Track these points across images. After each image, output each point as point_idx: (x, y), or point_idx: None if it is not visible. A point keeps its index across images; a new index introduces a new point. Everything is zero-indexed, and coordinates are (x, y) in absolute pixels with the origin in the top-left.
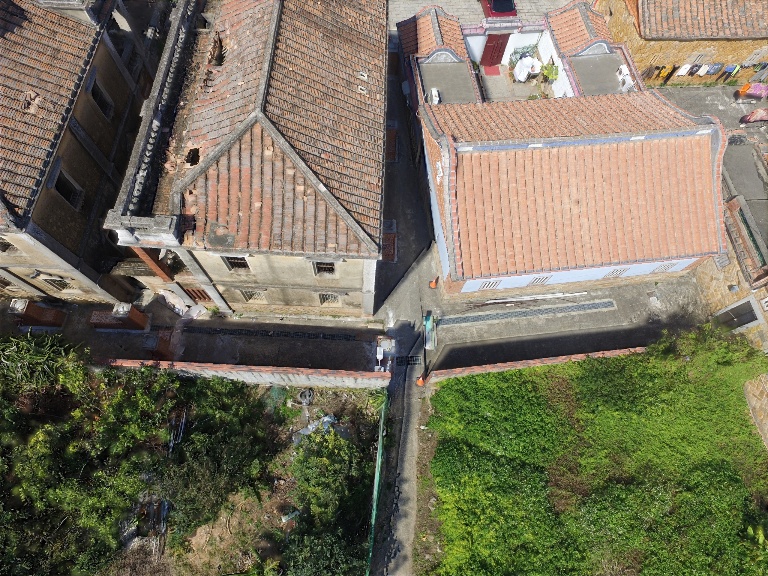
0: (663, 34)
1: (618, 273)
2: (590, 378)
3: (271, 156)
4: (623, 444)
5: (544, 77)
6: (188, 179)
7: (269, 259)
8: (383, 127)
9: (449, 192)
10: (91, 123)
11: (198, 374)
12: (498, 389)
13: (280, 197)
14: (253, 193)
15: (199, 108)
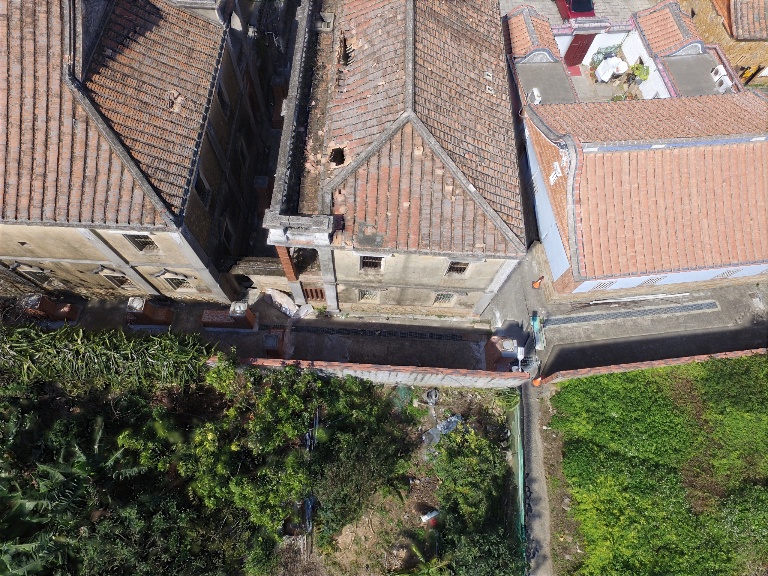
0: (755, 35)
1: (728, 274)
2: (716, 379)
3: (421, 156)
4: (754, 445)
5: (628, 77)
6: (339, 179)
7: (408, 259)
8: (512, 127)
9: (573, 192)
10: (216, 122)
11: (332, 373)
12: (624, 390)
13: (429, 197)
14: (402, 193)
15: (337, 108)
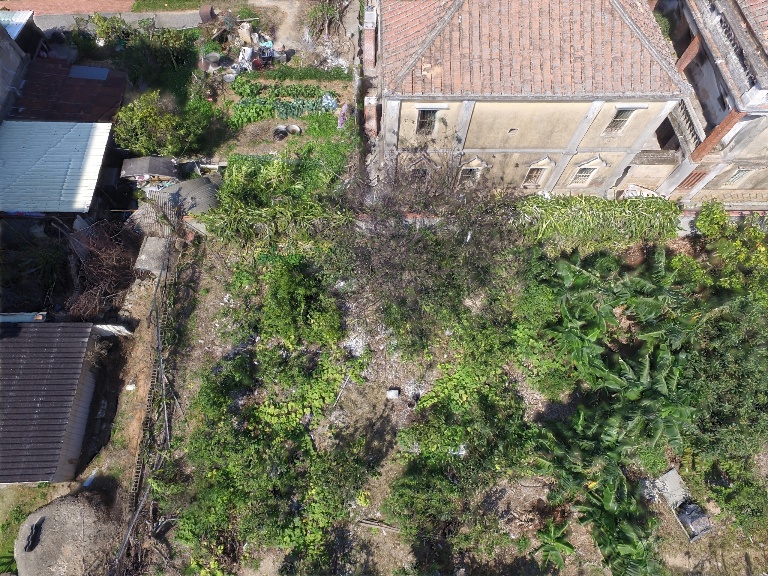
0: None
1: None
2: None
3: None
4: None
5: None
6: None
7: None
8: None
9: None
10: None
11: None
12: None
13: None
14: None
15: (756, 6)
